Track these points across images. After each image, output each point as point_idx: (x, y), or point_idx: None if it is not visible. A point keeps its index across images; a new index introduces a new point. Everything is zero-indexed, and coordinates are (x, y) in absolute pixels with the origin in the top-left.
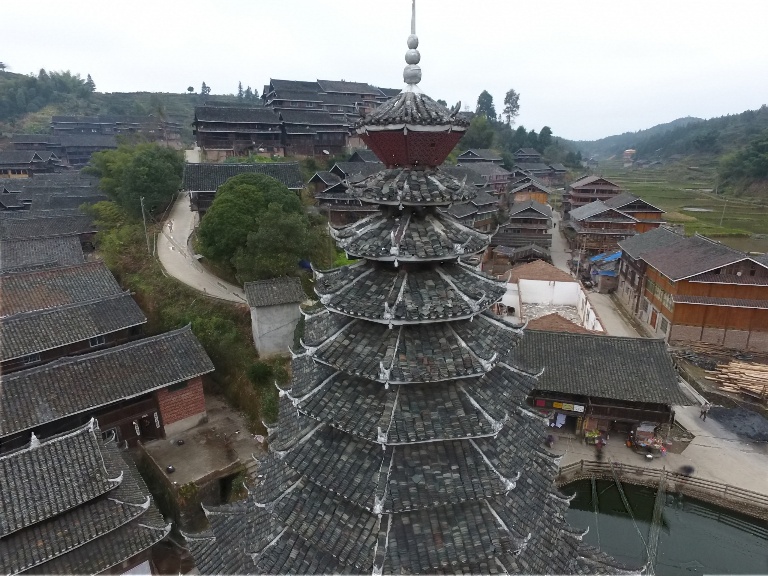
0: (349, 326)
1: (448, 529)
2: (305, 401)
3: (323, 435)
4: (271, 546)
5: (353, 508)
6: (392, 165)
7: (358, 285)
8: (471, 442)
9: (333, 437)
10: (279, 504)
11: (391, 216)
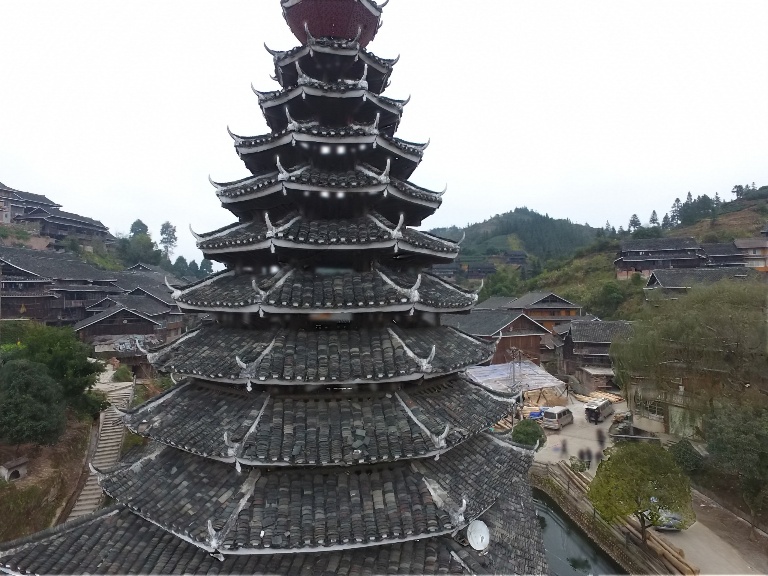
0: (307, 169)
1: (445, 345)
2: (283, 231)
3: (299, 279)
4: (252, 433)
5: (358, 342)
6: (327, 38)
7: (315, 127)
8: (430, 278)
9: (311, 279)
10: (262, 365)
11: (328, 81)
